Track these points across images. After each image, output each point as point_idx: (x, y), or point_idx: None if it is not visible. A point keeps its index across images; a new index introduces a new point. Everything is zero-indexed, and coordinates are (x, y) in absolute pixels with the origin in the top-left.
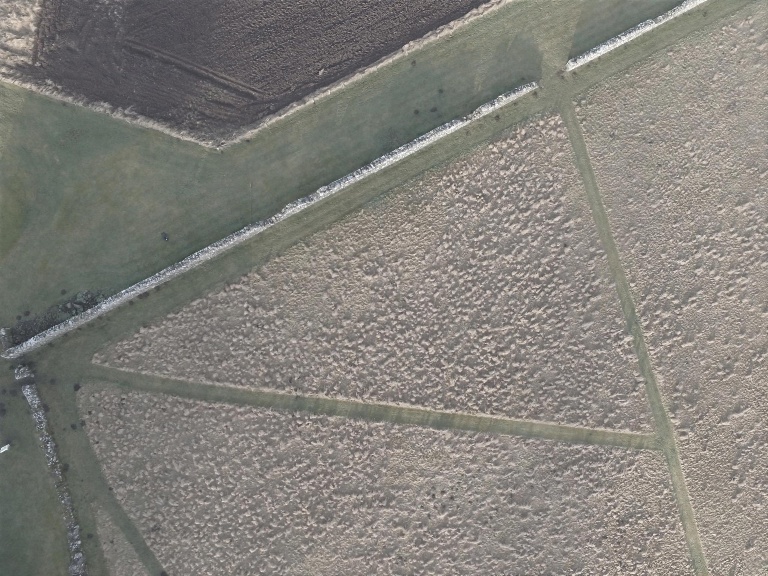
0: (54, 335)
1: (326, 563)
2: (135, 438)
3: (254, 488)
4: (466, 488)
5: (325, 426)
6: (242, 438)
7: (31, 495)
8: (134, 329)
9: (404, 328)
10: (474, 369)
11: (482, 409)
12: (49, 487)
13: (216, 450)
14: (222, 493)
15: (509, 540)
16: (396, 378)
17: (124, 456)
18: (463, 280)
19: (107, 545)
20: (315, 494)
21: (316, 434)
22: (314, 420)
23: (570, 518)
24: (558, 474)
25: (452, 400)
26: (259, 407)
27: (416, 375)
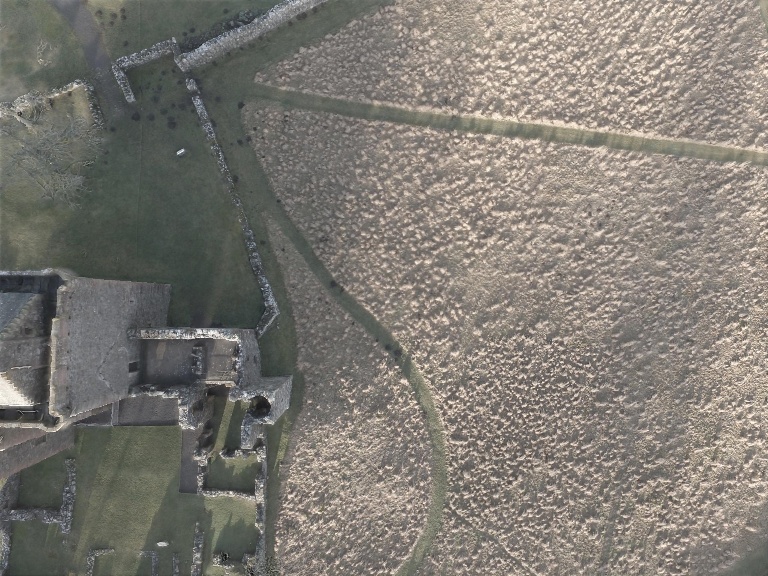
0: (221, 47)
1: (488, 278)
2: (299, 153)
3: (415, 204)
4: (621, 206)
5: (482, 144)
6: (402, 156)
7: (206, 199)
8: (293, 50)
9: (555, 49)
10: (625, 88)
11: (635, 128)
12: (223, 192)
13: (377, 166)
14: (385, 207)
15: (665, 258)
16: (549, 97)
17: (290, 170)
18: (611, 1)
19: (279, 252)
20: (474, 211)
21: (474, 152)
22: (471, 139)
23: (724, 238)
24: (711, 192)
25: (605, 119)
26: (417, 126)
27: (569, 94)
